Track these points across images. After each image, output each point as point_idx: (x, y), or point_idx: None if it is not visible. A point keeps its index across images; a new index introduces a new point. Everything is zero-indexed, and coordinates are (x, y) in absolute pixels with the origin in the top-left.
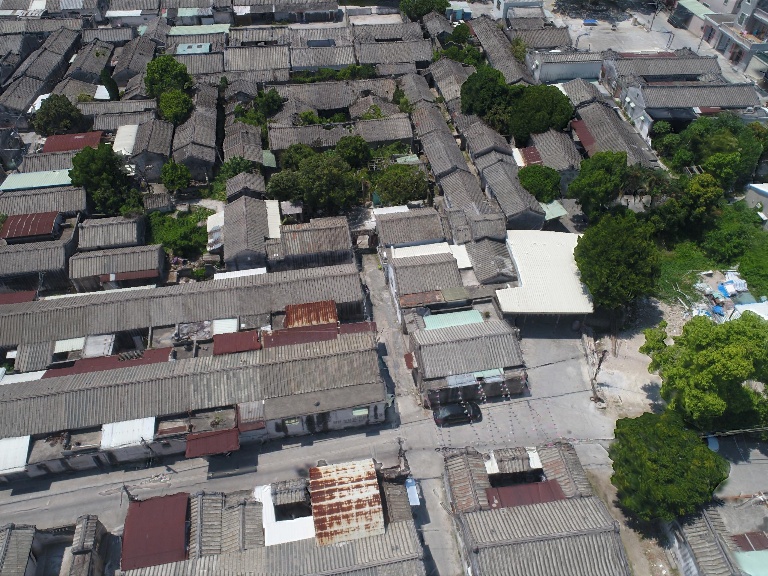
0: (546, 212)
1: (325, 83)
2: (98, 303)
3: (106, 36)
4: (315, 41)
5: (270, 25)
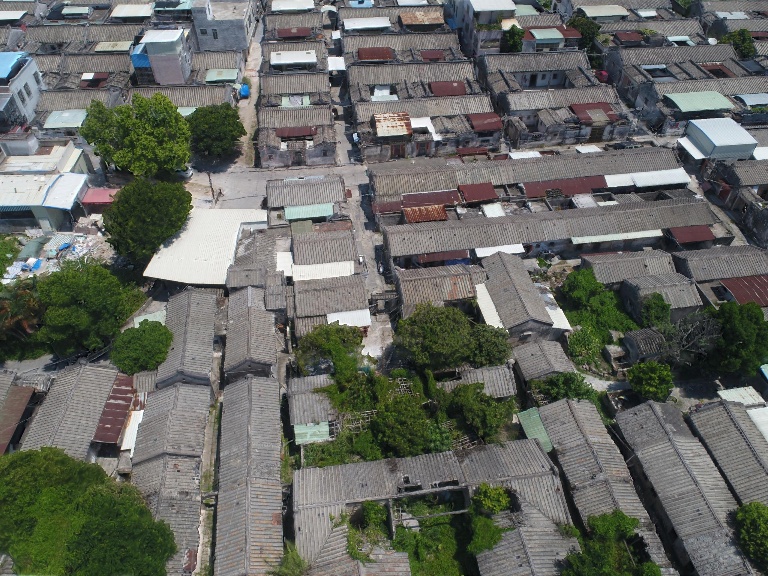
0: (161, 317)
1: None
2: (605, 213)
3: None
4: None
5: None
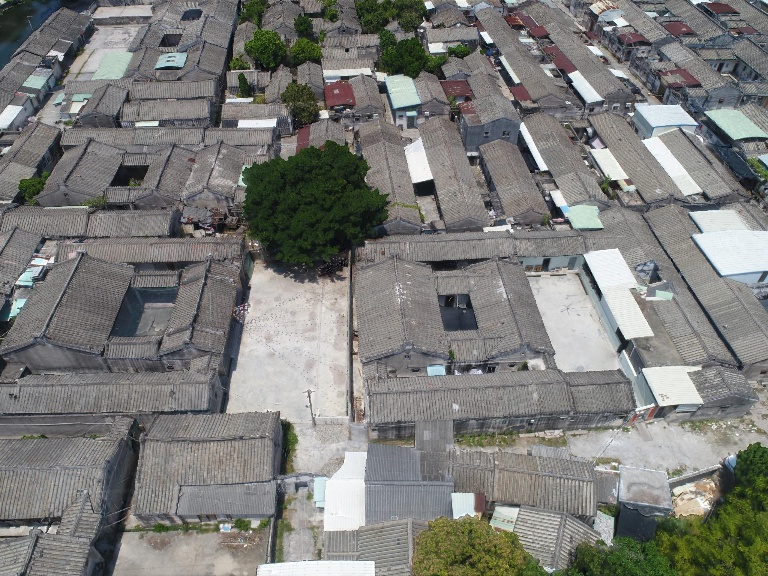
0: None
1: (283, 7)
2: None
3: (113, 102)
4: (190, 15)
5: (79, 57)
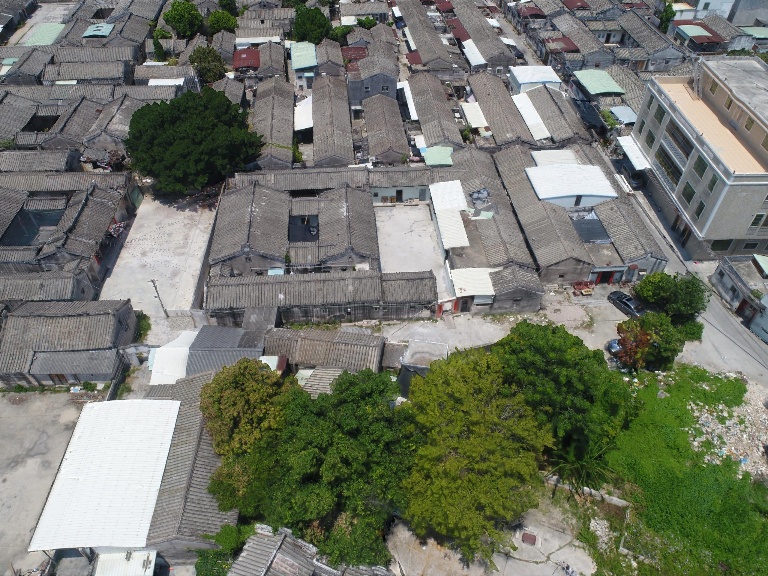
0: None
1: None
2: None
3: (37, 64)
4: None
5: (19, 30)
